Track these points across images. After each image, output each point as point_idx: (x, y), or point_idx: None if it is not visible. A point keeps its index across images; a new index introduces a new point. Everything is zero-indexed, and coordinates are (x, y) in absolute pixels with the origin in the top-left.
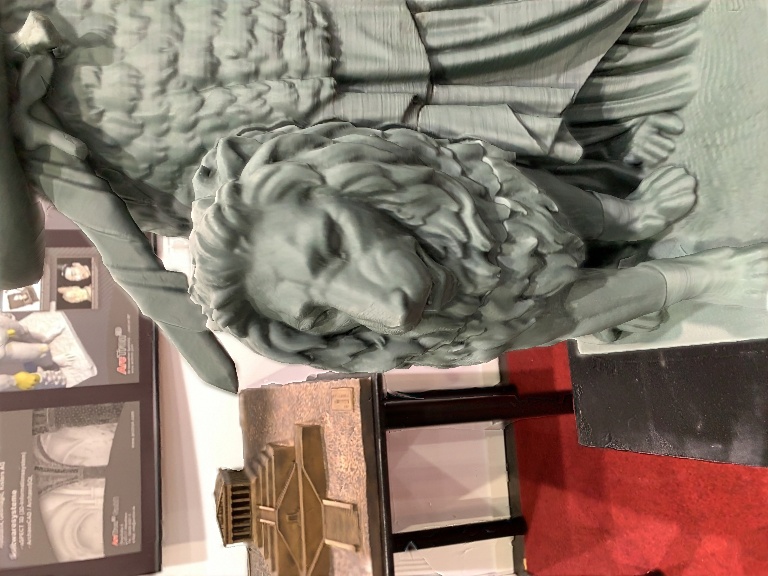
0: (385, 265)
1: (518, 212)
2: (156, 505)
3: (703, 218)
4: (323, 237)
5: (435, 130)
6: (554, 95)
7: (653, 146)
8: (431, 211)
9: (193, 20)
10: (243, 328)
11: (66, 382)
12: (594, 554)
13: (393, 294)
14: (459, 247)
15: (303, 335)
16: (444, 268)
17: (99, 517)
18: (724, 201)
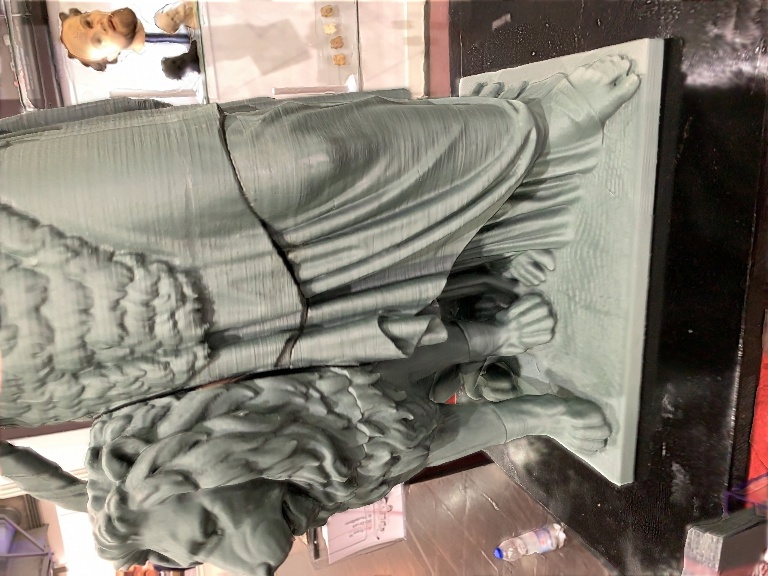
0: (253, 545)
1: (376, 436)
2: None
3: (555, 352)
4: (200, 534)
5: (307, 362)
6: (425, 292)
7: (527, 274)
8: (296, 470)
9: (61, 322)
10: (144, 559)
11: None
12: None
13: (259, 568)
14: (321, 486)
15: None
16: (307, 509)
17: None
18: (572, 350)
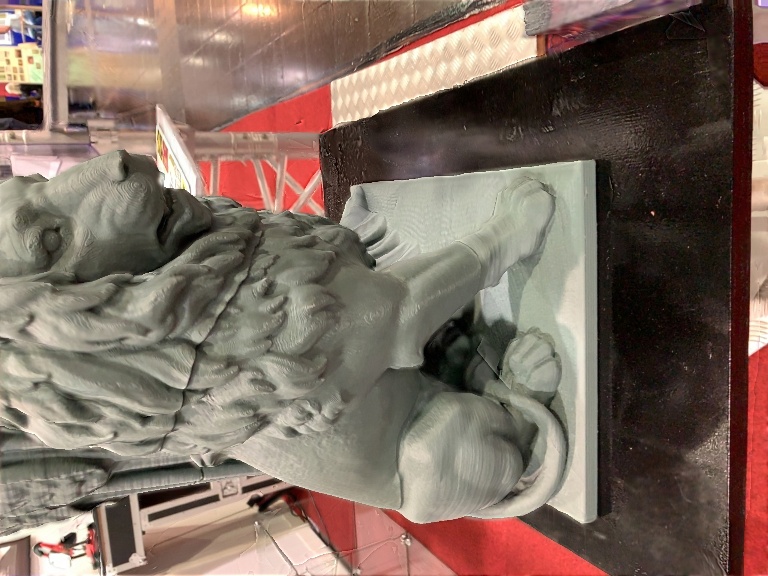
0: None
1: (263, 213)
2: None
3: None
4: None
5: None
6: None
7: None
8: None
9: None
10: None
11: None
12: None
13: None
14: None
15: None
16: None
17: None
18: None
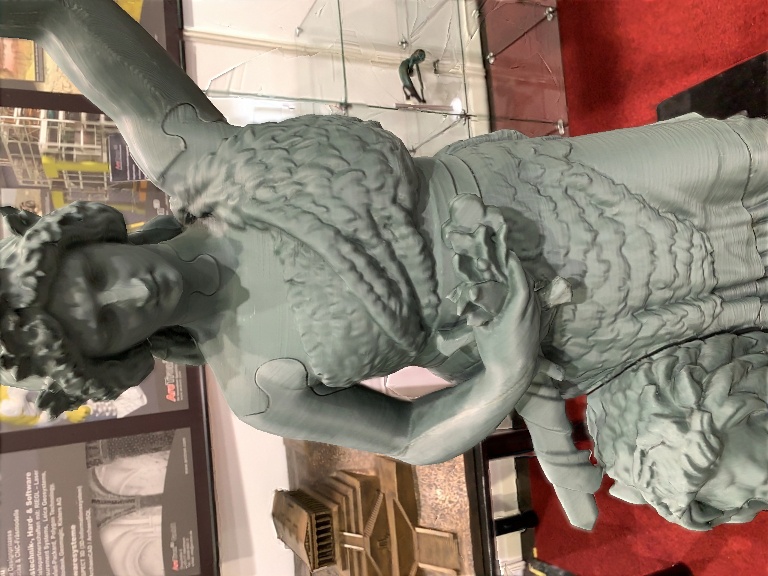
0: None
1: None
2: (212, 528)
3: None
4: None
5: None
6: None
7: None
8: None
9: (637, 260)
10: None
11: (117, 412)
12: (610, 546)
13: None
14: None
15: (709, 508)
16: None
17: (159, 544)
18: None
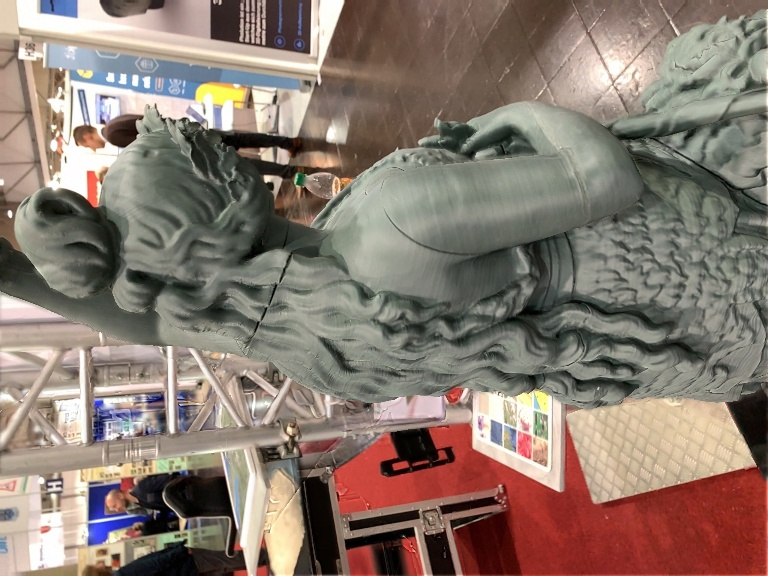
0: None
1: None
2: None
3: None
4: None
5: None
6: None
7: None
8: None
9: None
10: None
11: None
12: None
13: None
14: None
15: None
16: None
17: None
18: None
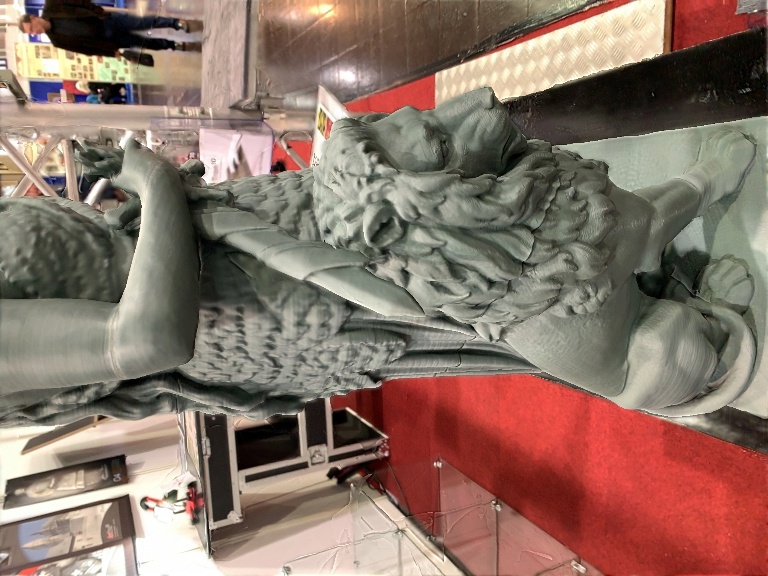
0: None
1: None
2: None
3: None
4: None
5: None
6: None
7: None
8: None
9: None
10: None
11: None
12: None
13: None
14: None
15: None
16: None
17: None
18: None
